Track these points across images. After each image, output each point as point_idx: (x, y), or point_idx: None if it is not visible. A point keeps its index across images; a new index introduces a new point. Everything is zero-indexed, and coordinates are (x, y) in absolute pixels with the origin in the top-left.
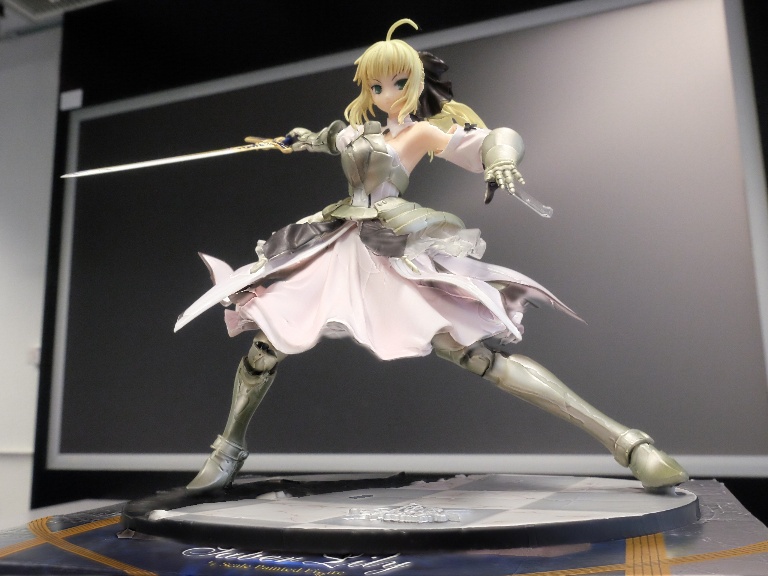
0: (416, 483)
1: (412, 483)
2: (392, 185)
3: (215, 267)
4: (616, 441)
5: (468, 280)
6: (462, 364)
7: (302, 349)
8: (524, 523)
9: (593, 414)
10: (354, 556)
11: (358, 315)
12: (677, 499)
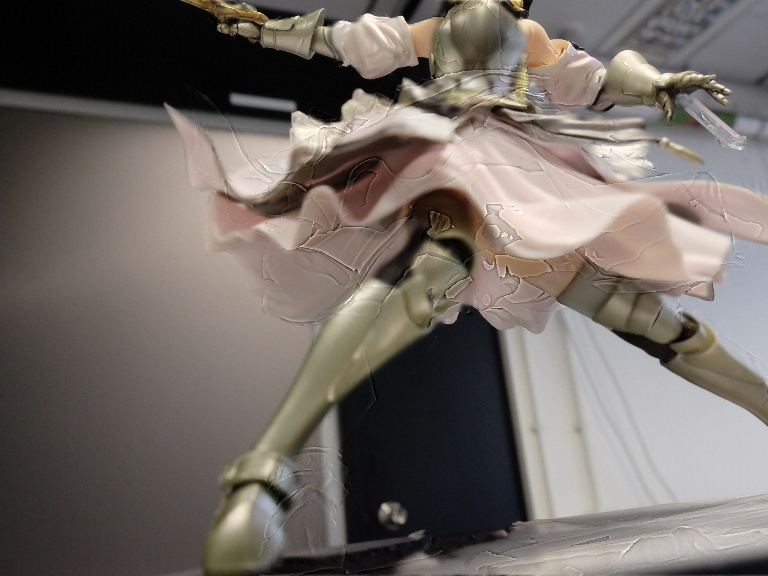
0: (529, 540)
1: (524, 541)
2: None
3: None
4: None
5: None
6: (655, 322)
7: (624, 224)
8: None
9: None
10: None
11: None
12: None
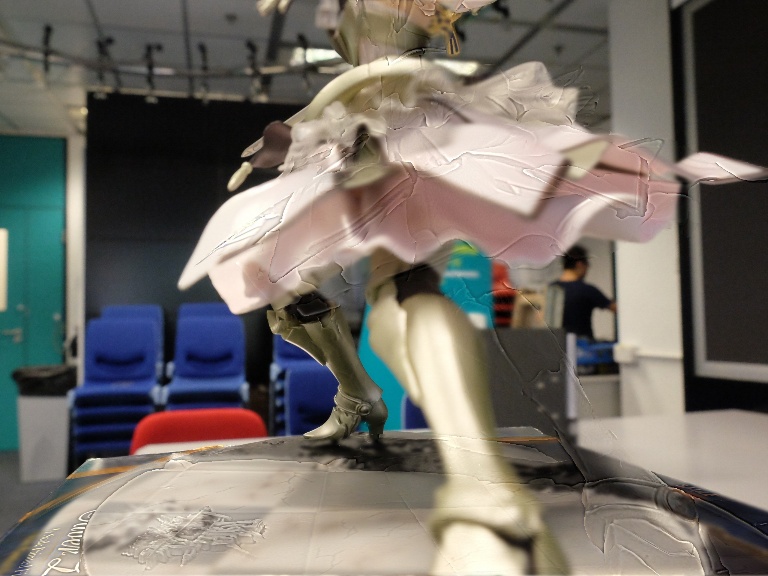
0: (537, 481)
1: (533, 480)
2: (406, 32)
3: None
4: None
5: None
6: None
7: None
8: None
9: (591, 422)
10: None
11: None
12: None
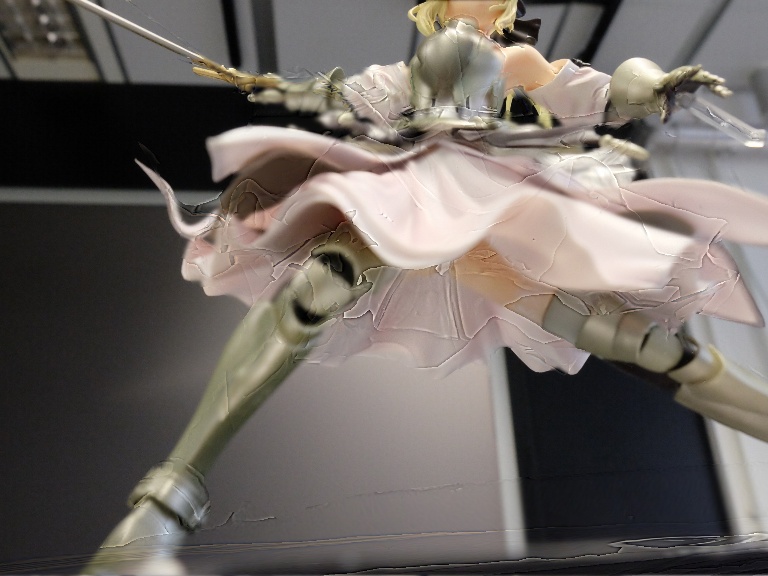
0: None
1: None
2: (494, 98)
3: None
4: None
5: None
6: (643, 347)
7: (490, 220)
8: None
9: None
10: None
11: None
12: None
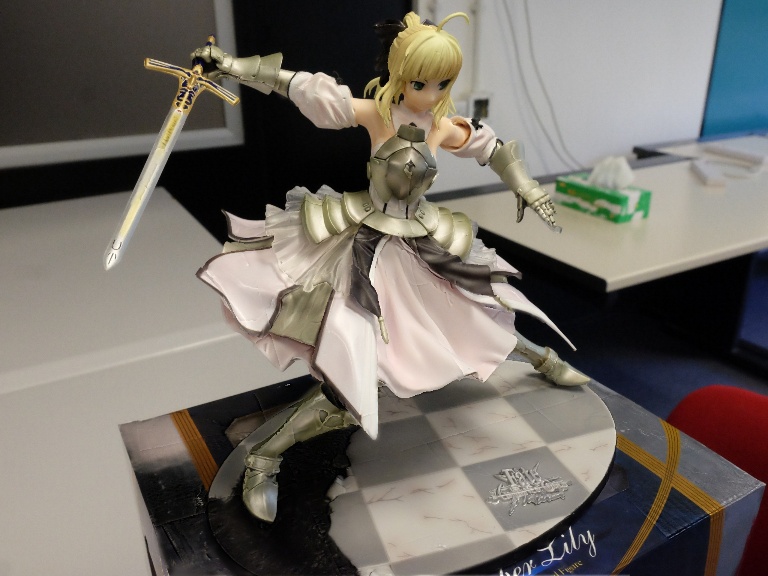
0: None
1: None
2: None
3: (218, 288)
4: (545, 362)
5: (523, 300)
6: None
7: None
8: (603, 471)
9: None
10: (552, 541)
11: (445, 343)
12: (587, 394)
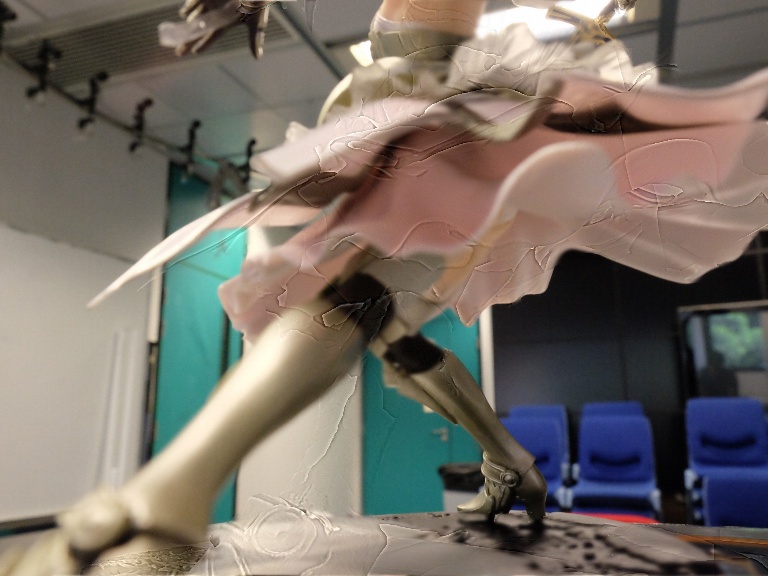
0: None
1: (627, 574)
2: None
3: None
4: None
5: None
6: None
7: None
8: None
9: None
10: None
11: None
12: None
